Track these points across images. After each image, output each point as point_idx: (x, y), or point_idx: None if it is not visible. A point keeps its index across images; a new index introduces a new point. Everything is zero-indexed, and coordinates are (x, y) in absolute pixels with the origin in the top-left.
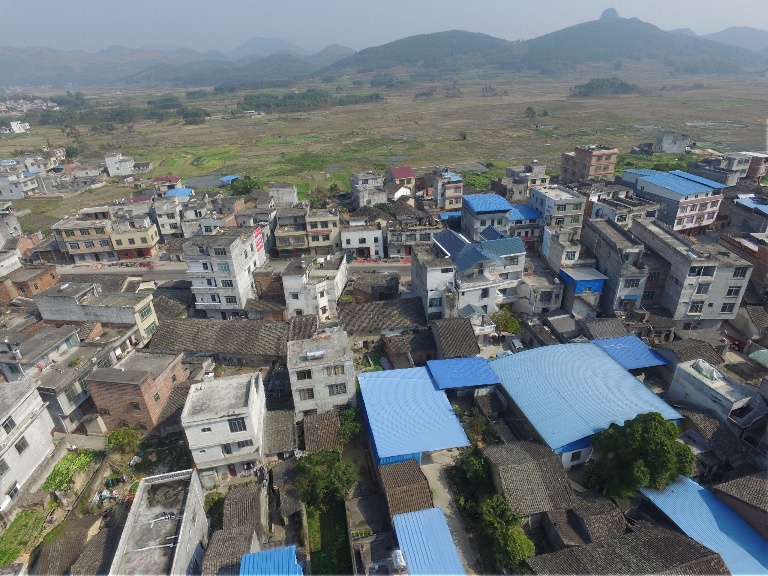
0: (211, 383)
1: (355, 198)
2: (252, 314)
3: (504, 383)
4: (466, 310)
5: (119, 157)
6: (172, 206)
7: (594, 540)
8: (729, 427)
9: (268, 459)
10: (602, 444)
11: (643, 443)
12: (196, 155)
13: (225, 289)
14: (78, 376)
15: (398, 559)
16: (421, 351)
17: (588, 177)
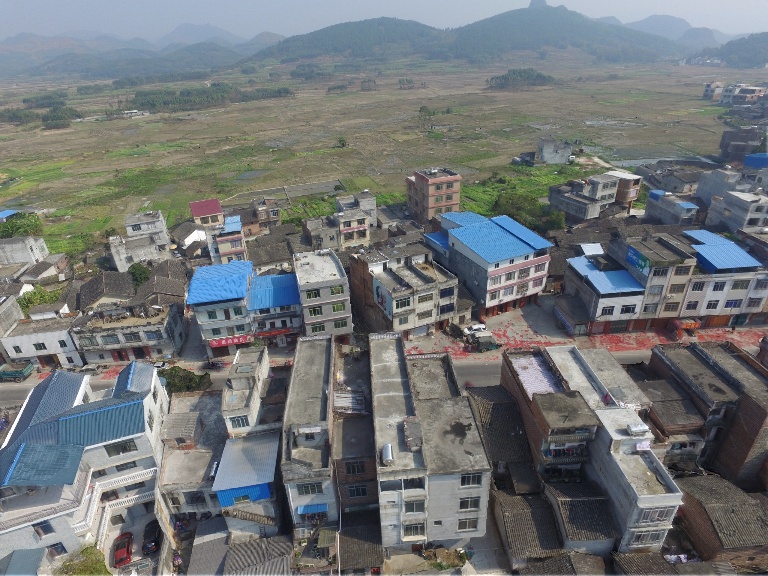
0: None
1: None
2: None
3: None
4: None
5: None
6: None
7: None
8: None
9: None
10: None
11: None
12: (14, 174)
13: None
14: None
15: None
16: None
17: (428, 210)
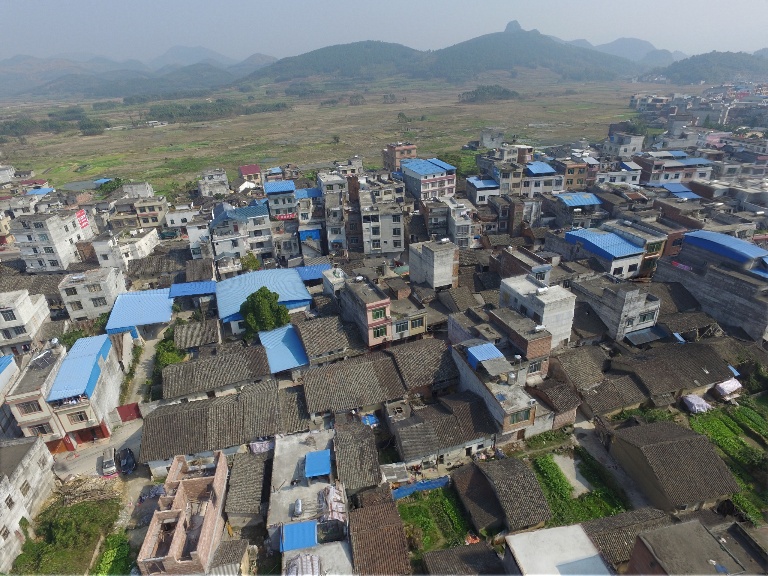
0: None
1: (199, 191)
2: None
3: (217, 292)
4: (220, 255)
5: None
6: (28, 202)
7: None
8: None
9: None
10: (241, 310)
11: (253, 303)
12: (83, 163)
13: (48, 255)
14: None
15: None
16: None
17: (396, 168)
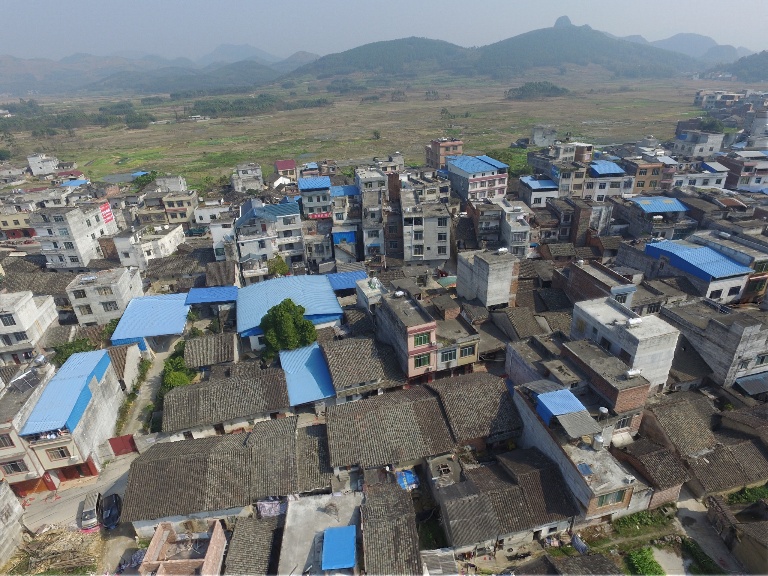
0: None
1: (233, 186)
2: (94, 271)
3: (238, 300)
4: (245, 257)
5: (42, 157)
6: (60, 193)
7: None
8: (370, 317)
9: (48, 353)
10: (261, 324)
11: (274, 317)
12: (124, 156)
13: (68, 250)
14: None
15: (37, 358)
16: (203, 287)
17: (439, 165)
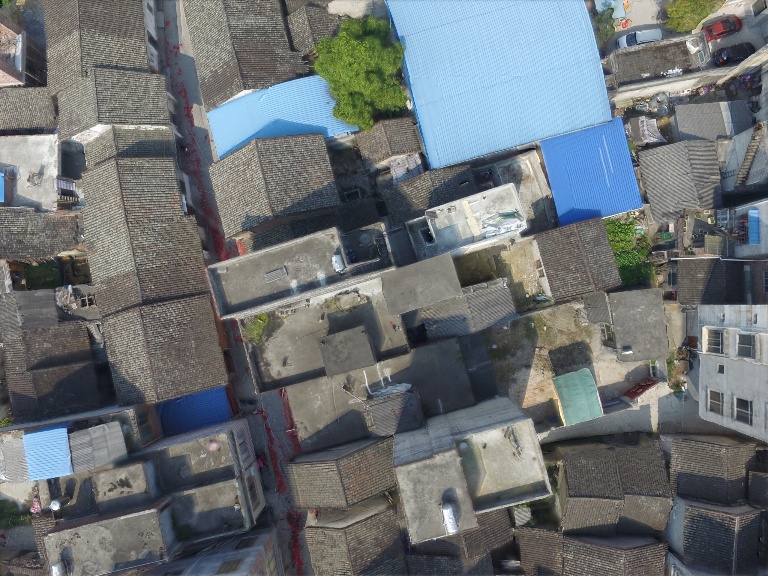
0: None
1: None
2: None
3: None
4: None
5: None
6: None
7: (289, 17)
8: None
9: None
10: None
11: None
12: None
13: None
14: None
15: None
16: None
17: None
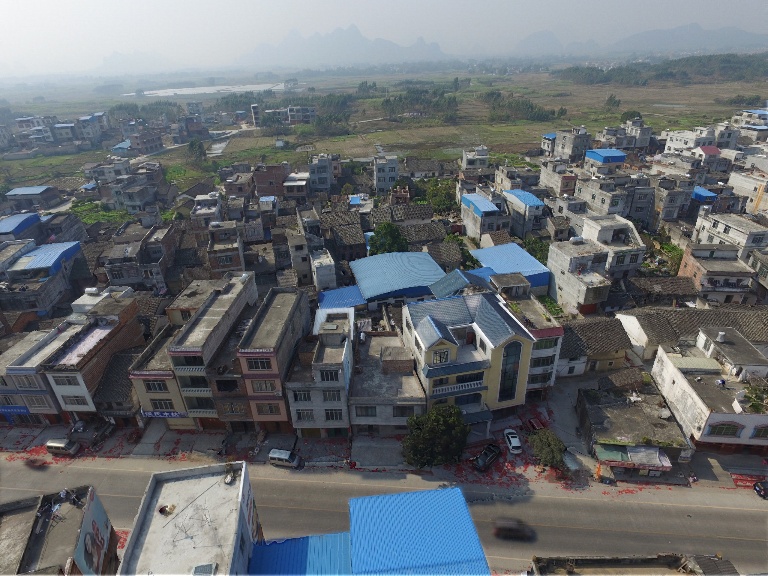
0: (623, 224)
1: None
2: None
3: None
4: None
5: None
6: None
7: None
8: None
9: None
10: None
11: None
12: None
13: None
14: (762, 260)
15: None
16: None
17: None
